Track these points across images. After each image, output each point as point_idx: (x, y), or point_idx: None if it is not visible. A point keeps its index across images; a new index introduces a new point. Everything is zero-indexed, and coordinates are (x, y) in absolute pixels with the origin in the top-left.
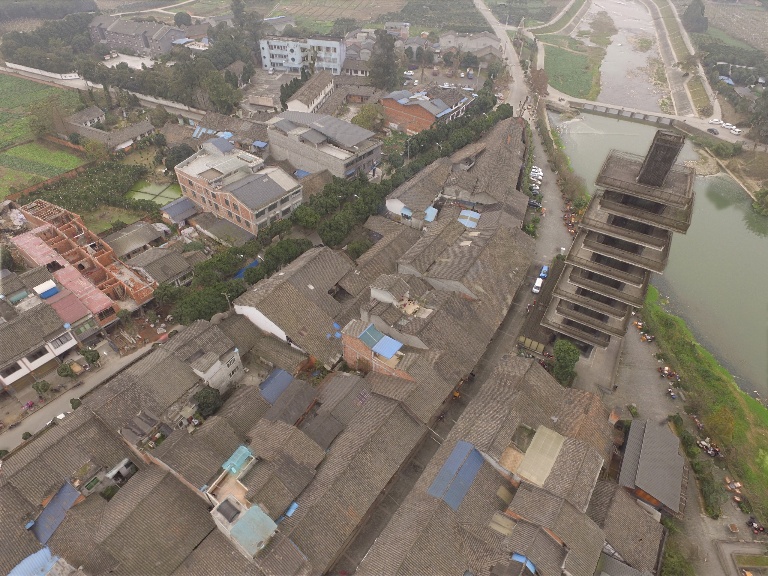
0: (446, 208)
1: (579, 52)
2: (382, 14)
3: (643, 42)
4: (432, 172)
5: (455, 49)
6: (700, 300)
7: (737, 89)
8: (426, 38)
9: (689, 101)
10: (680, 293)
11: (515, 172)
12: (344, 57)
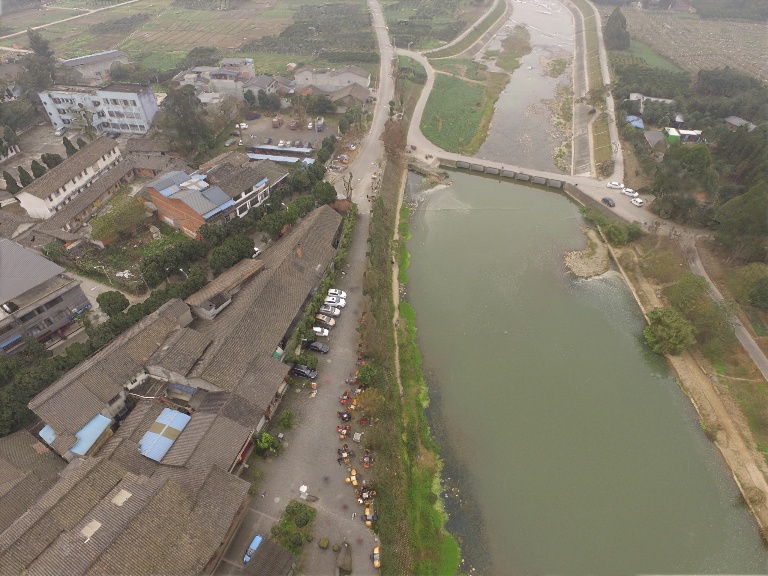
0: (141, 405)
1: (476, 81)
2: (253, 40)
3: (556, 64)
4: (132, 339)
5: (311, 89)
6: (525, 571)
7: (647, 134)
8: (292, 71)
9: (589, 152)
10: (496, 553)
11: (287, 314)
12: (154, 110)
